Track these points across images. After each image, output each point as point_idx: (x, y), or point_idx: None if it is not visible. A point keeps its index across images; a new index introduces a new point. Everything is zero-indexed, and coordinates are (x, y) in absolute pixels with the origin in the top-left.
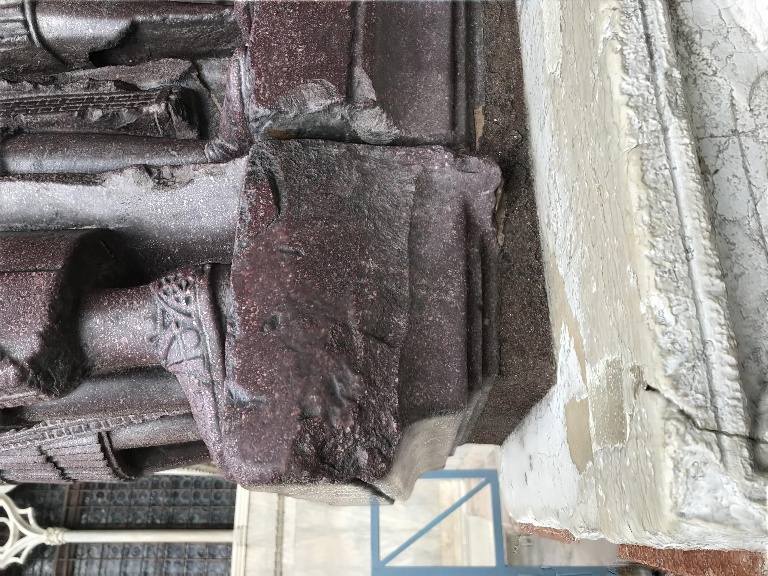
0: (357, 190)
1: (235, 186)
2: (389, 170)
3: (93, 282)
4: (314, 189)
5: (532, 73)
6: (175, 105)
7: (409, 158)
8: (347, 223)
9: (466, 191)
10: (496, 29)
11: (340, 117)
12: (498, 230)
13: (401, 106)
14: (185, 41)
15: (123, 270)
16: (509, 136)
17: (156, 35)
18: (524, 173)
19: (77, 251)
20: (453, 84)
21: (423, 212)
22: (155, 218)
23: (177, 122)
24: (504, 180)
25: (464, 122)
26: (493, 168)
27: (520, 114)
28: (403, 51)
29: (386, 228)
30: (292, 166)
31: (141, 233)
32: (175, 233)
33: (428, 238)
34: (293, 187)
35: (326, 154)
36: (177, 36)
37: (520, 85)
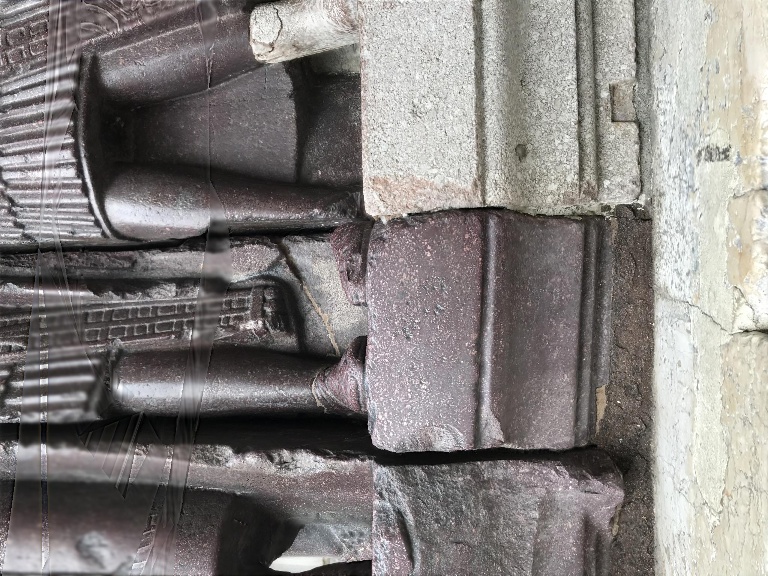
0: (485, 534)
1: (356, 478)
2: (513, 495)
3: (236, 569)
4: (444, 538)
5: (669, 400)
6: (272, 321)
7: (533, 479)
8: (477, 574)
9: (587, 506)
10: (628, 293)
11: (465, 450)
12: (613, 524)
13: (525, 421)
14: (268, 223)
15: (254, 529)
16: (632, 423)
17: (237, 223)
18: (644, 465)
19: (220, 554)
20: (578, 372)
21: (545, 534)
22: (279, 489)
23: (275, 333)
24: (623, 473)
25: (587, 414)
26: (617, 491)
27: (646, 401)
28: (528, 355)
29: (512, 564)
30: (420, 506)
31: (266, 497)
32: (298, 498)
33: (549, 558)
34: (424, 535)
35: (452, 488)
36: (260, 222)
37: (649, 368)
